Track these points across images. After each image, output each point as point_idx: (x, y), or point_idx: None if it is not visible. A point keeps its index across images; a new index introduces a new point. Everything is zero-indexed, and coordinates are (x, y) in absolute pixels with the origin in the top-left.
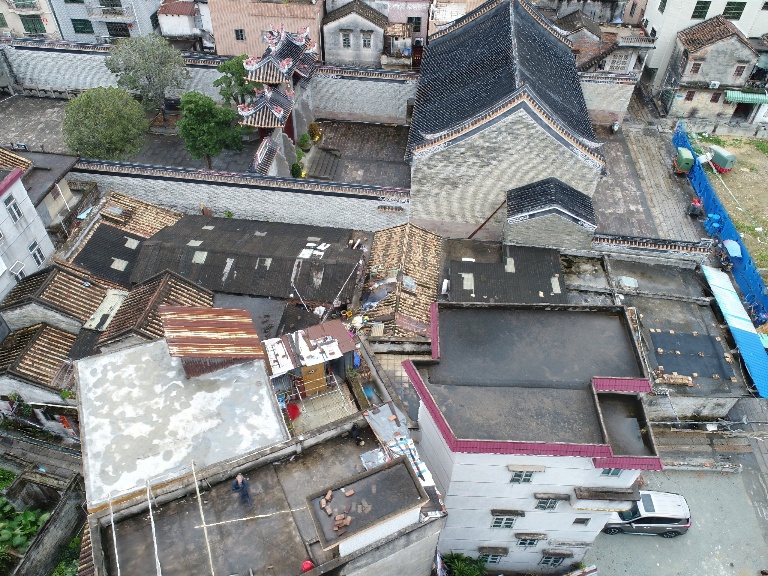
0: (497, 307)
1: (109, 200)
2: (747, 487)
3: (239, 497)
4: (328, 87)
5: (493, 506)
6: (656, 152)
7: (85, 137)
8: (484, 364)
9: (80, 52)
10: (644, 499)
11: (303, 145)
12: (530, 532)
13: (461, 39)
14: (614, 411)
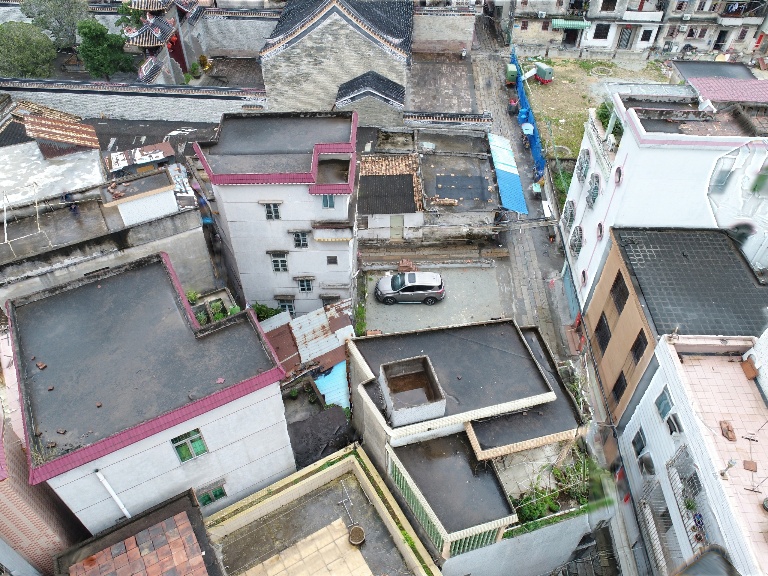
0: (266, 116)
1: (19, 105)
2: (497, 275)
3: (71, 214)
4: (218, 27)
5: (266, 247)
6: (495, 71)
7: (1, 62)
8: (248, 144)
9: (1, 5)
10: (410, 276)
11: (194, 72)
12: (303, 275)
13: None
14: (333, 168)
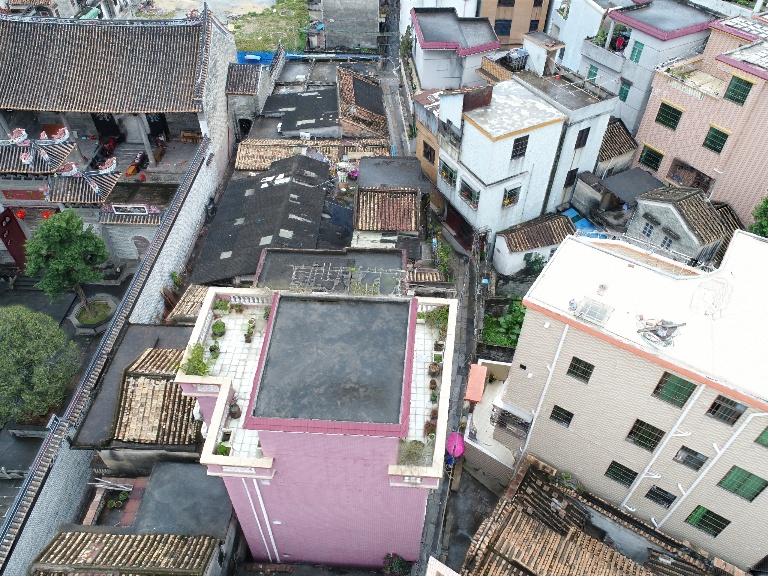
0: None
1: None
2: None
3: None
4: None
5: None
6: None
7: None
8: None
9: None
10: None
11: None
12: None
13: (1, 68)
14: None
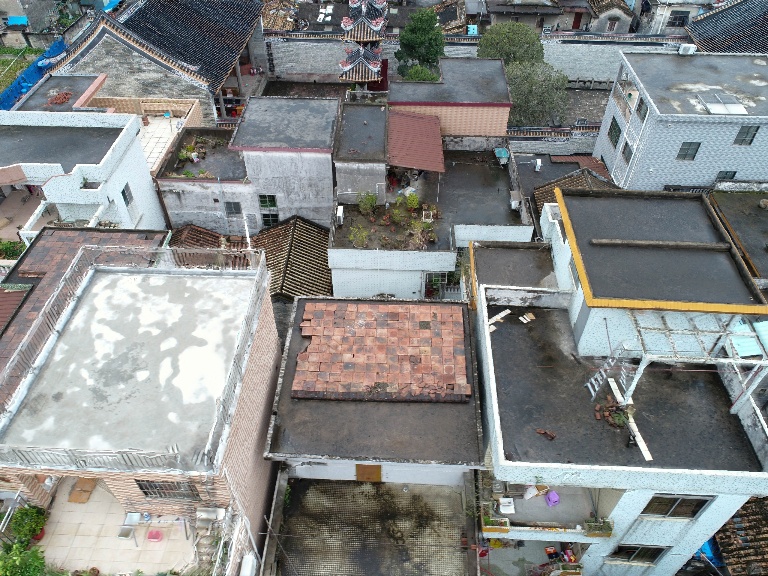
0: None
1: None
2: None
3: None
4: None
5: None
6: None
7: None
8: None
9: None
10: None
11: None
12: None
13: None
14: None
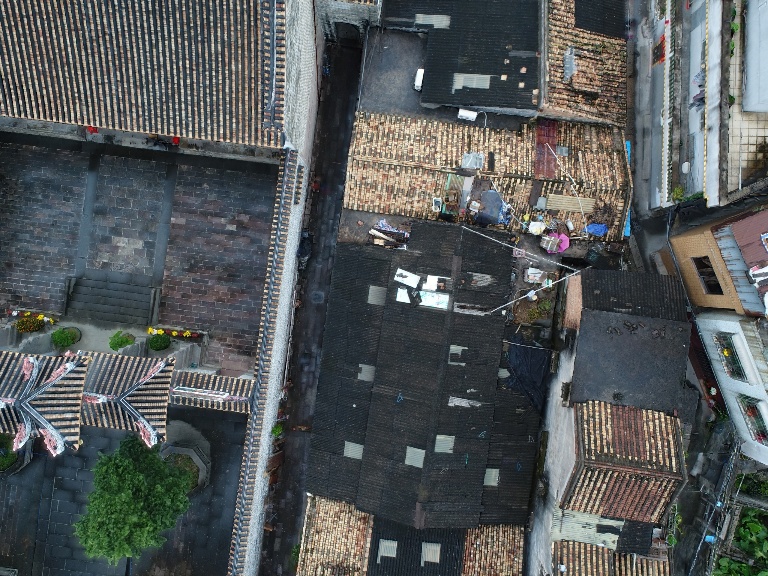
0: None
1: None
2: None
3: None
4: None
5: None
6: None
7: None
8: None
9: None
10: None
11: (73, 340)
12: None
13: None
14: None
